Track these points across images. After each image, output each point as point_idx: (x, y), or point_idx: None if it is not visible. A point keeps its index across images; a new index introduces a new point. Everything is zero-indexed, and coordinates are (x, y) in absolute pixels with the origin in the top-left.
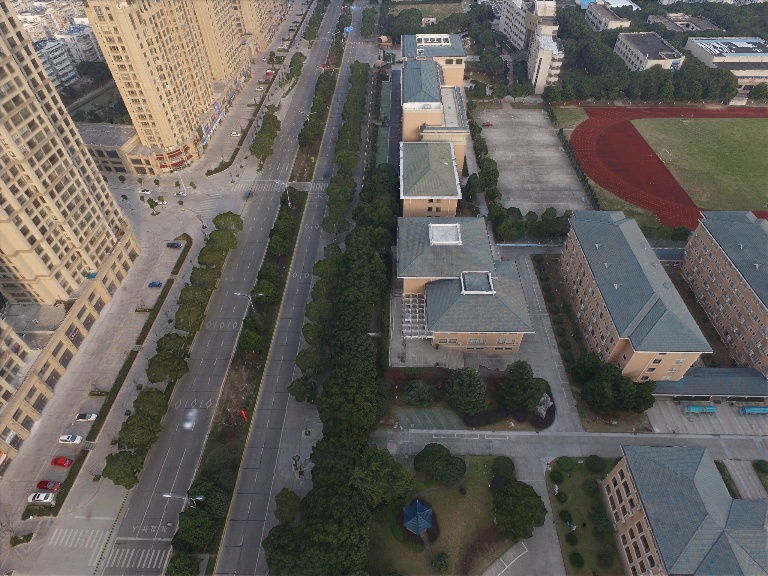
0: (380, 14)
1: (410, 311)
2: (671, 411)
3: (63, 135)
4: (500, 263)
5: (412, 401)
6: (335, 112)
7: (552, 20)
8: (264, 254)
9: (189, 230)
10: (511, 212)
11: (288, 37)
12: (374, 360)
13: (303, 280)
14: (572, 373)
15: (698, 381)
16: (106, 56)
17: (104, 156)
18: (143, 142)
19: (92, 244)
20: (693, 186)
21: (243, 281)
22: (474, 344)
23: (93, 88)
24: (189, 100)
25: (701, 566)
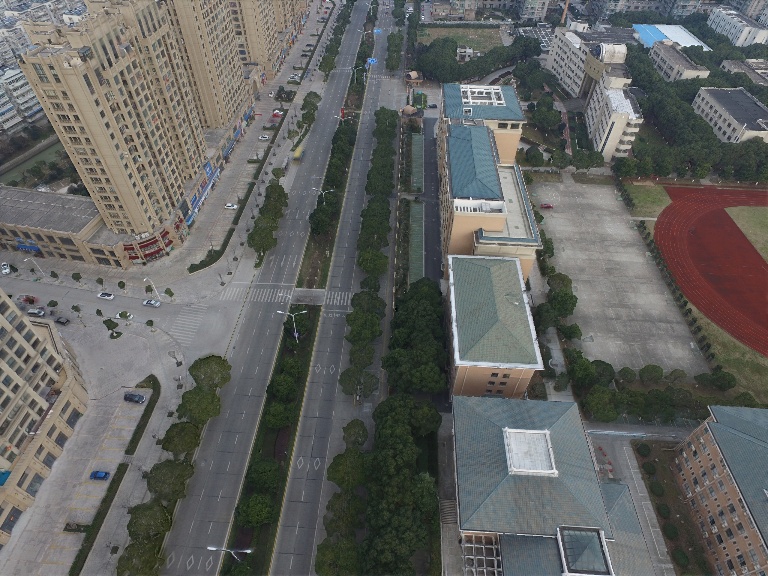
0: None
1: (474, 573)
2: None
3: None
4: (608, 494)
5: None
6: (356, 177)
7: (621, 69)
8: (258, 419)
9: (158, 368)
10: (601, 371)
11: (300, 65)
12: None
13: (312, 473)
14: None
15: None
16: (54, 124)
17: (56, 242)
18: (108, 224)
19: (2, 433)
20: None
21: (226, 471)
22: None
23: None
24: (171, 170)
25: None
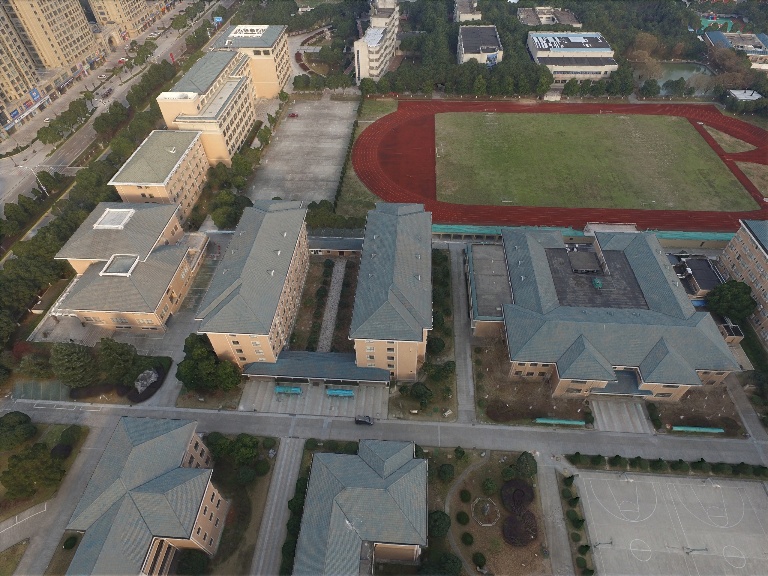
0: None
1: None
2: (267, 391)
3: None
4: (169, 248)
5: (23, 373)
6: None
7: (390, 12)
8: None
9: None
10: (237, 200)
11: (163, 26)
12: (5, 334)
13: None
14: (185, 352)
15: (294, 364)
16: None
17: None
18: None
19: None
20: (447, 180)
21: None
22: (119, 323)
23: None
24: None
25: (94, 523)
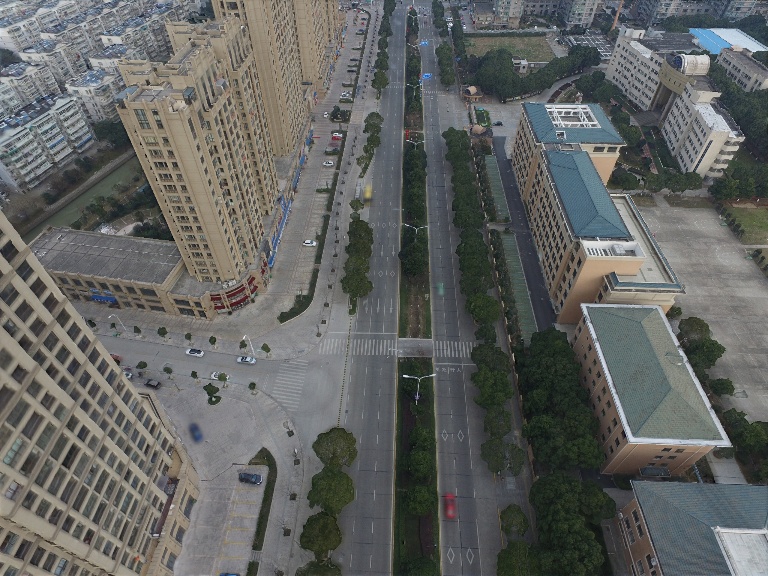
0: (457, 52)
1: None
2: None
3: (88, 386)
4: None
5: None
6: (435, 205)
7: (705, 81)
8: (392, 500)
9: (268, 439)
10: None
11: (350, 82)
12: None
13: (467, 569)
14: None
15: None
16: (147, 171)
17: (136, 293)
18: (191, 272)
19: (132, 544)
20: None
21: (369, 567)
22: None
23: (114, 156)
24: (255, 209)
25: None
